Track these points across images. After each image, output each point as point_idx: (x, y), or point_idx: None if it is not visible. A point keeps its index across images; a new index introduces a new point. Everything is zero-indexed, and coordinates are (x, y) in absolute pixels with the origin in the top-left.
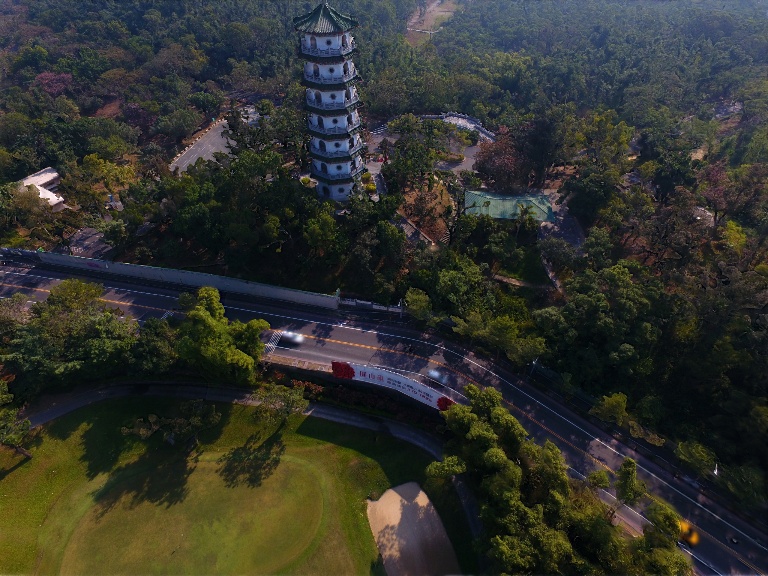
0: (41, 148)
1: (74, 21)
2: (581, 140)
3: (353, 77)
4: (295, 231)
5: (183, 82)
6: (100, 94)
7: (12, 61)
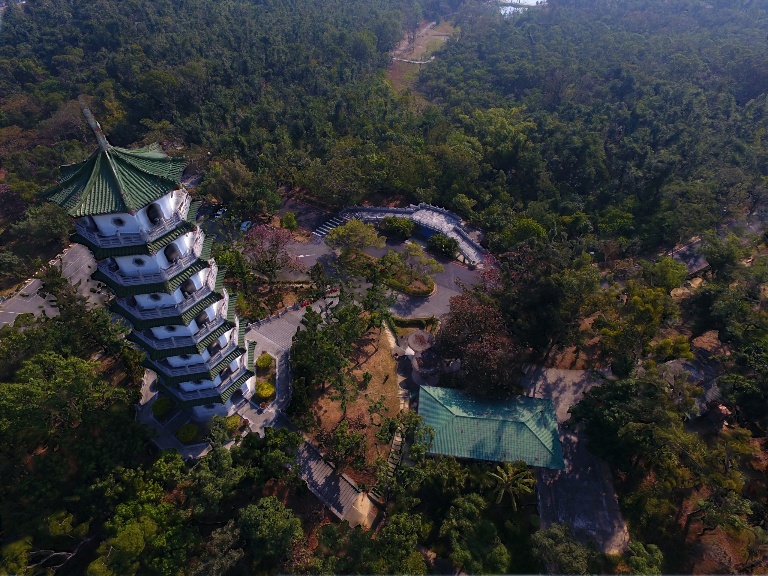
0: None
1: None
2: (610, 334)
3: (190, 264)
4: (96, 524)
5: (82, 150)
6: None
7: None
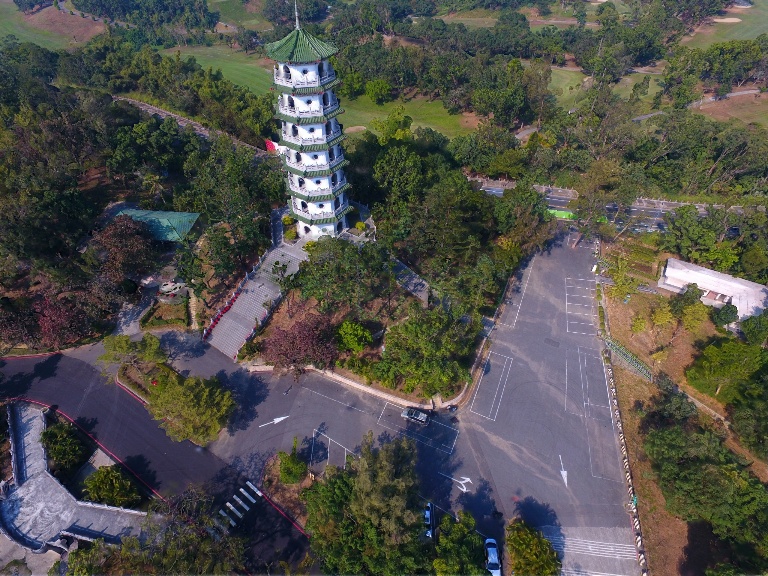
0: None
1: None
2: None
3: None
4: None
5: None
6: None
7: None
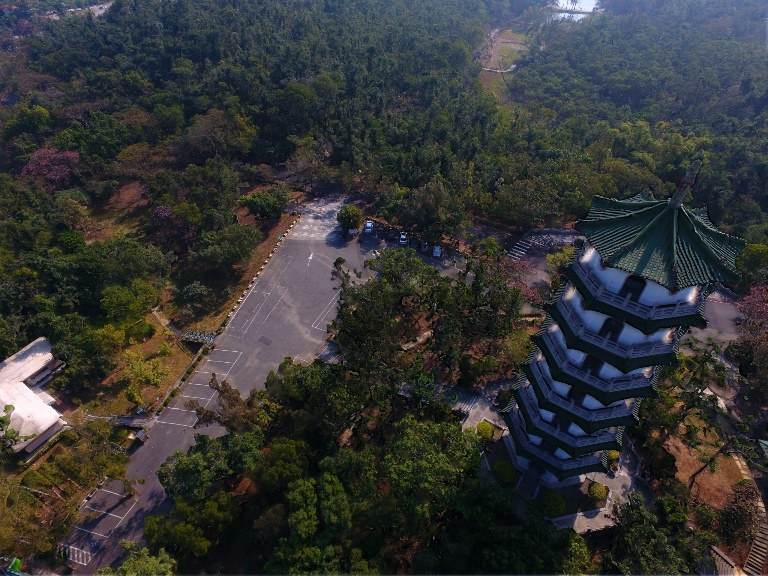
0: (29, 303)
1: (83, 70)
2: None
3: None
4: None
5: (229, 168)
6: (115, 175)
7: (4, 125)
